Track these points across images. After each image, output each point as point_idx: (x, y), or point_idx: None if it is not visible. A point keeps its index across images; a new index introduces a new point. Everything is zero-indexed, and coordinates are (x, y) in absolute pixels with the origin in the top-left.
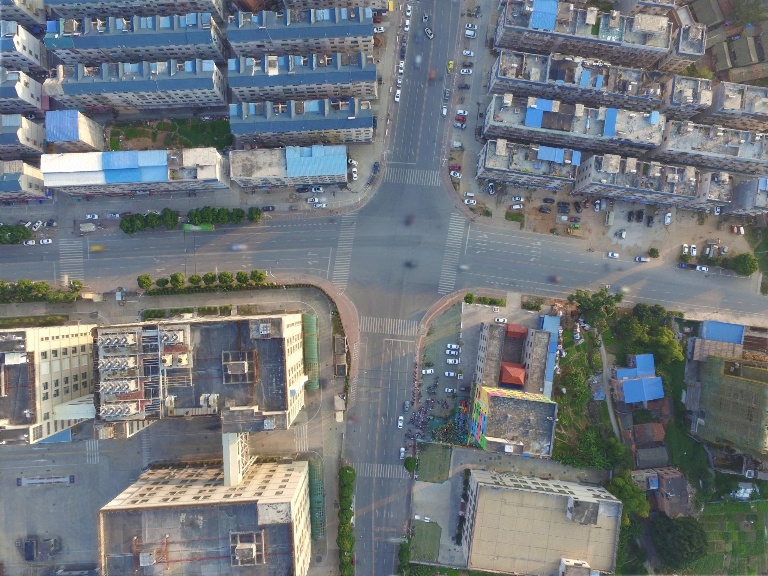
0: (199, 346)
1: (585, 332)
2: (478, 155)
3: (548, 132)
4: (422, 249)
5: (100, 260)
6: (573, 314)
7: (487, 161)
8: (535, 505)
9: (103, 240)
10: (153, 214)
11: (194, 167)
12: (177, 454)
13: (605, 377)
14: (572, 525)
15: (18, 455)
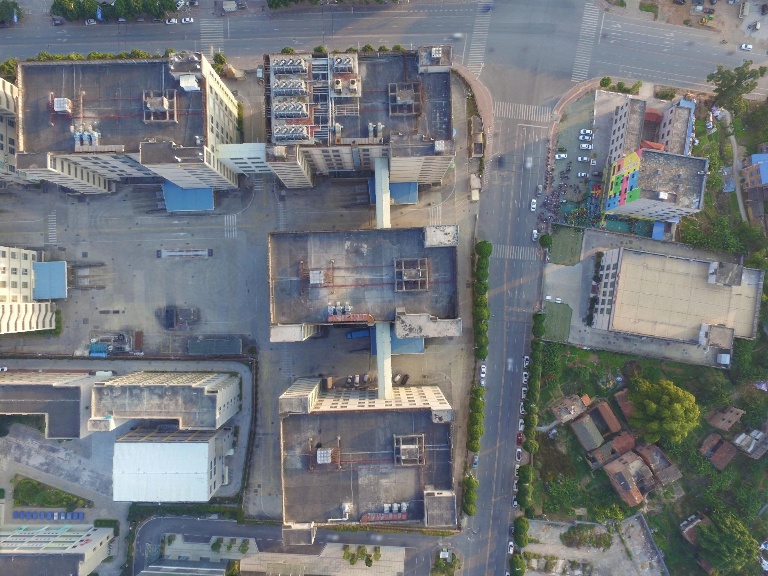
0: (365, 79)
1: (717, 122)
2: None
3: None
4: (556, 37)
5: (240, 40)
6: (707, 102)
7: None
8: (676, 271)
9: (243, 21)
10: None
11: None
12: None
13: (735, 169)
14: (713, 291)
15: (158, 228)
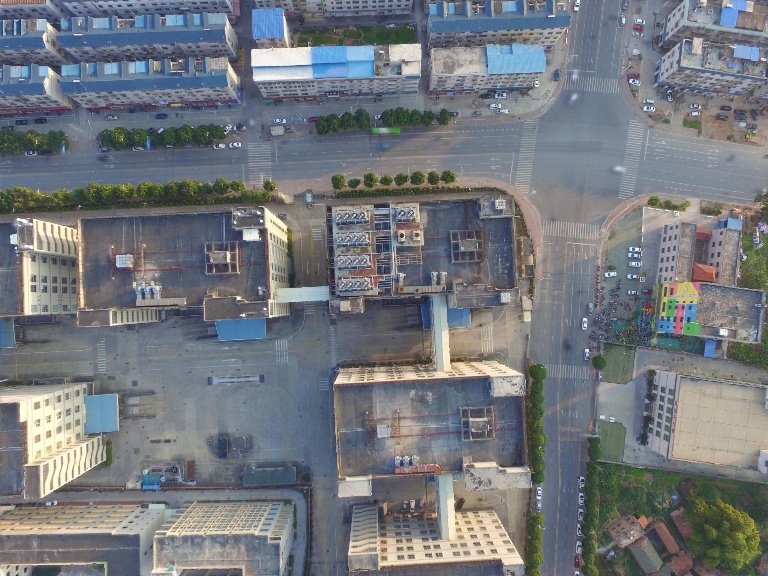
0: (426, 226)
1: (763, 237)
2: (656, 63)
3: (740, 33)
4: (602, 155)
5: (288, 164)
6: (753, 218)
7: (682, 60)
8: (733, 397)
9: (291, 144)
10: (348, 114)
11: (399, 63)
12: (365, 354)
13: None
14: None
15: (209, 354)
